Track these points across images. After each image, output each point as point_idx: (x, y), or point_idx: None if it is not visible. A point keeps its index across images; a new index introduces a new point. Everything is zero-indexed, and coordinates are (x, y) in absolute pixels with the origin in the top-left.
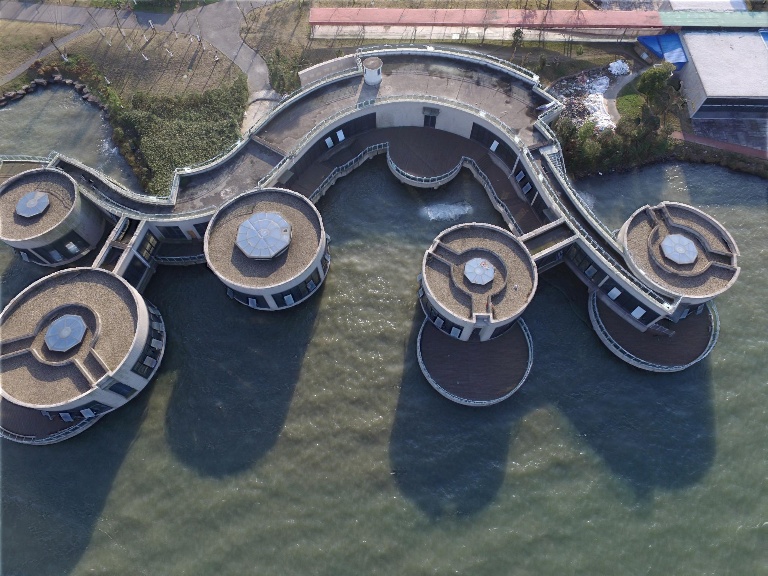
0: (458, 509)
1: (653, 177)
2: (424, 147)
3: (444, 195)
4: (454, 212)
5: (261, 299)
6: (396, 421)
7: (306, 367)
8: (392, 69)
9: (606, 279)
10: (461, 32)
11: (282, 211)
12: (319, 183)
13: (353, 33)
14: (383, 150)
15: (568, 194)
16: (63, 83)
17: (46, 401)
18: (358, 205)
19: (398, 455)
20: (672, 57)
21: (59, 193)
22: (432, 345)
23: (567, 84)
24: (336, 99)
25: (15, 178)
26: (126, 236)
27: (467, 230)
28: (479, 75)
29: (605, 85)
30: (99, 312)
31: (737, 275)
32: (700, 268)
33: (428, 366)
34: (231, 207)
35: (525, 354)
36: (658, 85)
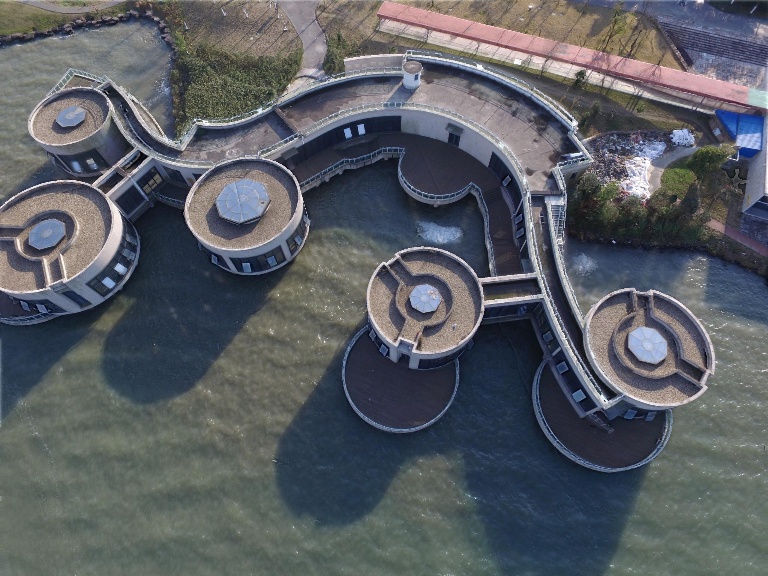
0: (318, 518)
1: (672, 263)
2: (439, 163)
3: (441, 215)
4: (444, 235)
5: (222, 259)
6: (299, 414)
7: (242, 335)
8: (435, 78)
9: (558, 350)
10: (526, 59)
11: (270, 184)
12: (325, 169)
13: (418, 34)
14: (398, 155)
15: (554, 251)
16: (152, 19)
17: (8, 286)
18: (356, 200)
19: (287, 446)
20: (745, 141)
21: (96, 113)
22: (362, 355)
23: (617, 139)
24: (368, 93)
25: (68, 90)
26: (132, 166)
27: (433, 255)
28: (519, 106)
29: (658, 151)
30: (81, 225)
31: (700, 394)
32: (662, 372)
33: (349, 373)
34: (228, 167)
35: (448, 396)
36: (709, 166)
